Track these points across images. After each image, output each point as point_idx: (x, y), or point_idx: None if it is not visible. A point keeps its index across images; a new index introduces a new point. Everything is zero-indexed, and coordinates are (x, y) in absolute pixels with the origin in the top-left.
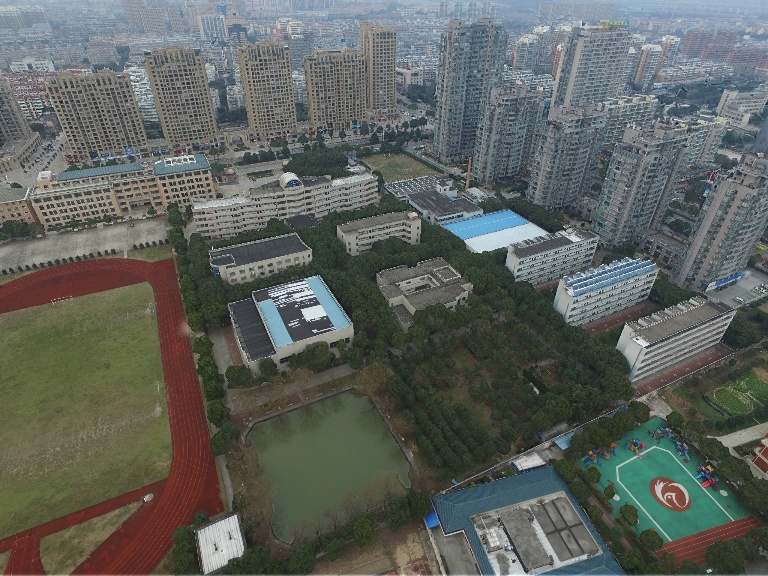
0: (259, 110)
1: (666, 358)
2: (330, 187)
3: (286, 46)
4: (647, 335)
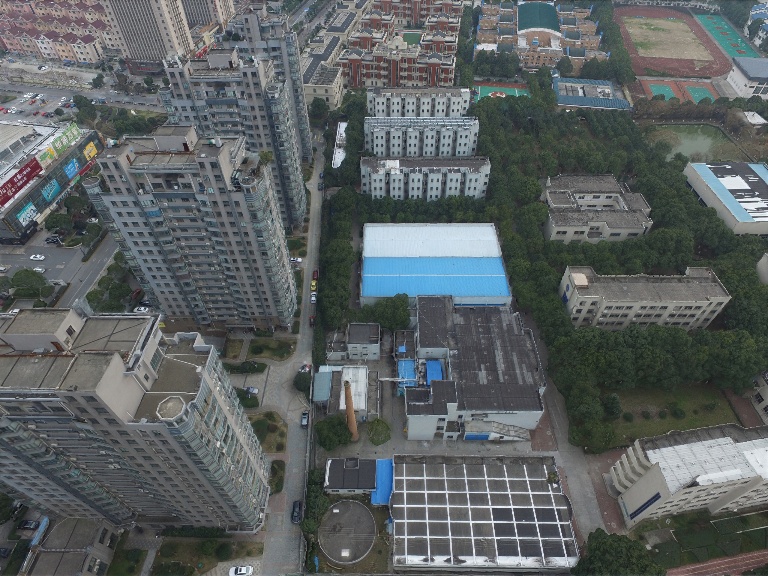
0: None
1: None
2: None
3: None
4: (456, 91)
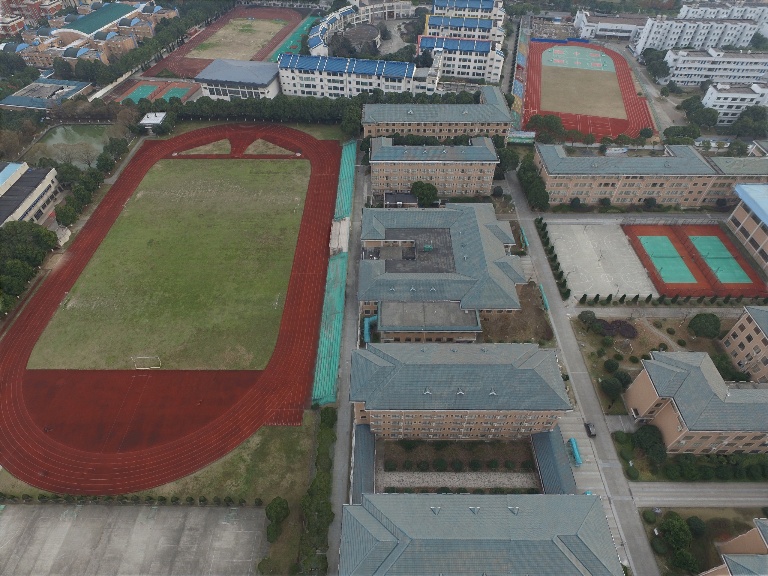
0: None
1: None
2: None
3: None
4: None
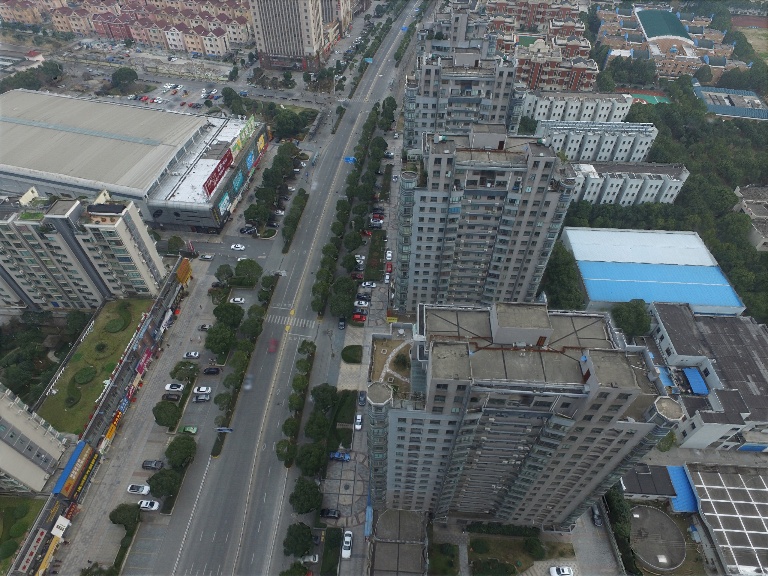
0: None
1: None
2: None
3: None
4: (619, 97)
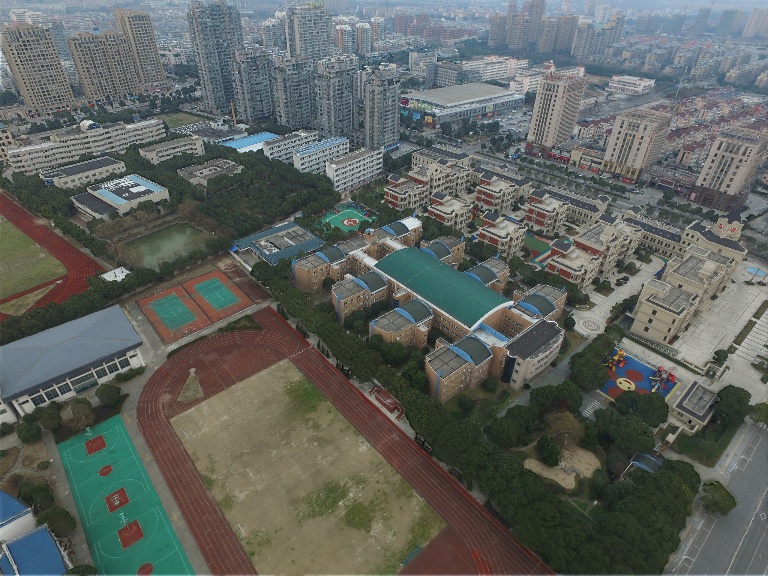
0: (33, 87)
1: (351, 177)
2: (125, 129)
3: (46, 28)
4: (336, 163)
